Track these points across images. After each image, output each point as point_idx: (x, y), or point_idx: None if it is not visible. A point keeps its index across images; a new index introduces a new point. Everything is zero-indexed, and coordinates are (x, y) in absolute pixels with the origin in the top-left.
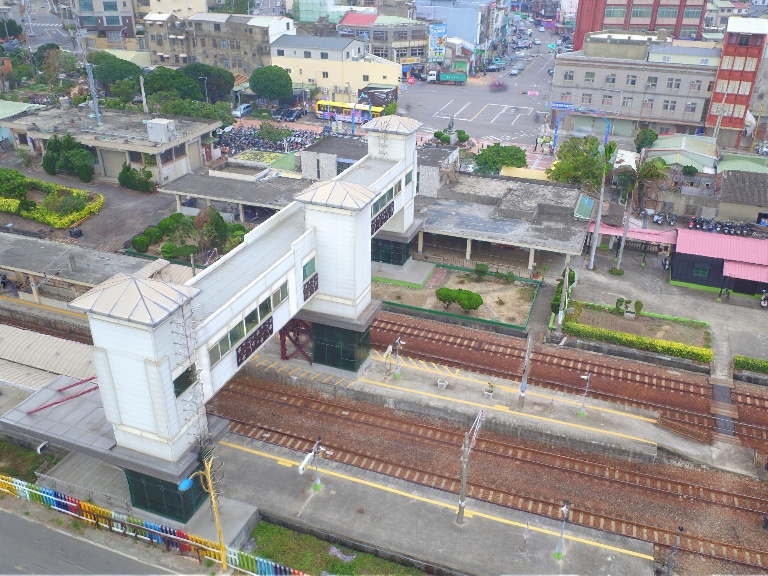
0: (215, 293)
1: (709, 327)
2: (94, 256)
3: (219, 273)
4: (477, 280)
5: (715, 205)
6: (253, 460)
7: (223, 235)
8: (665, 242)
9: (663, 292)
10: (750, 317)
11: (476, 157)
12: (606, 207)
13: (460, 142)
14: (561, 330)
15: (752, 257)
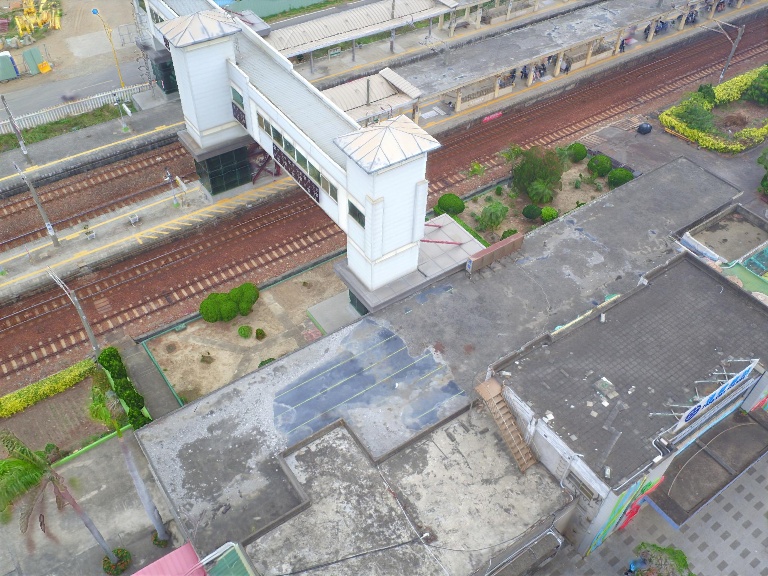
0: (183, 2)
1: None
2: (469, 74)
3: (207, 8)
4: None
5: None
6: (179, 119)
7: (523, 181)
8: None
9: (16, 573)
10: None
11: None
12: None
13: None
14: (100, 365)
15: None
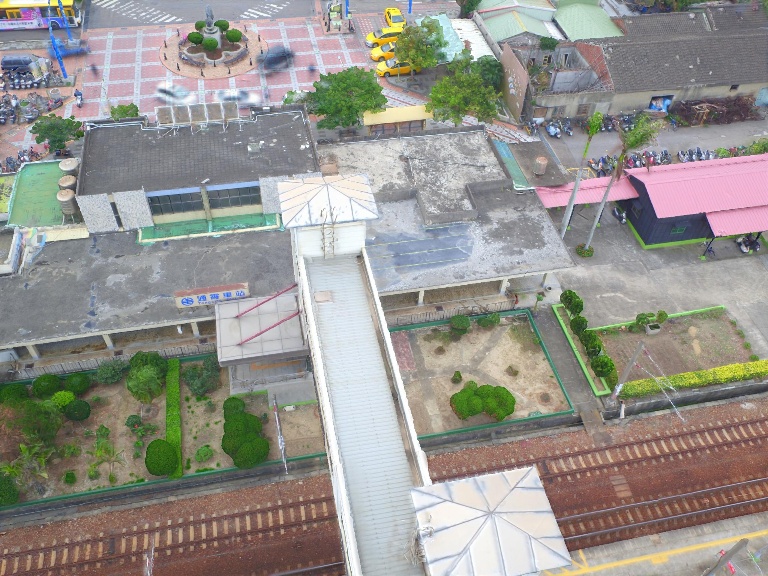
0: None
1: (726, 311)
2: None
3: None
4: (453, 336)
5: (609, 99)
6: None
7: (53, 434)
8: (627, 198)
9: (648, 267)
10: (745, 275)
11: (314, 100)
12: (545, 165)
13: (225, 39)
14: None
15: (729, 200)
